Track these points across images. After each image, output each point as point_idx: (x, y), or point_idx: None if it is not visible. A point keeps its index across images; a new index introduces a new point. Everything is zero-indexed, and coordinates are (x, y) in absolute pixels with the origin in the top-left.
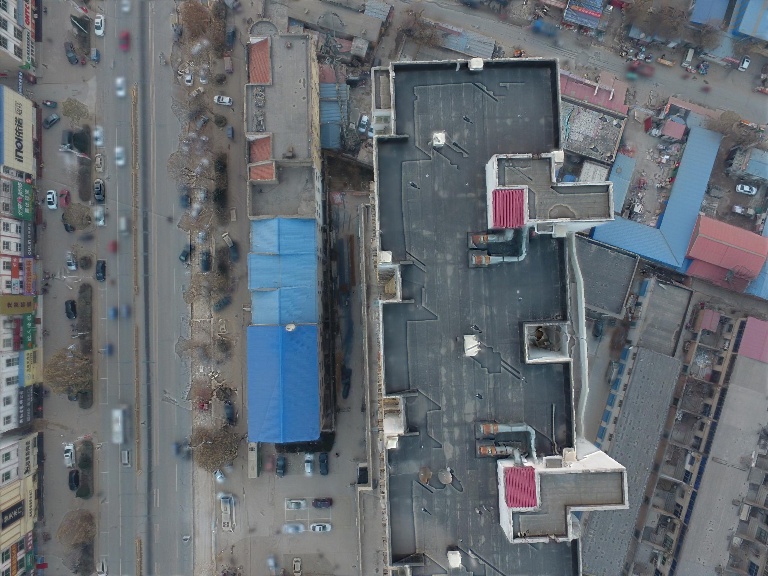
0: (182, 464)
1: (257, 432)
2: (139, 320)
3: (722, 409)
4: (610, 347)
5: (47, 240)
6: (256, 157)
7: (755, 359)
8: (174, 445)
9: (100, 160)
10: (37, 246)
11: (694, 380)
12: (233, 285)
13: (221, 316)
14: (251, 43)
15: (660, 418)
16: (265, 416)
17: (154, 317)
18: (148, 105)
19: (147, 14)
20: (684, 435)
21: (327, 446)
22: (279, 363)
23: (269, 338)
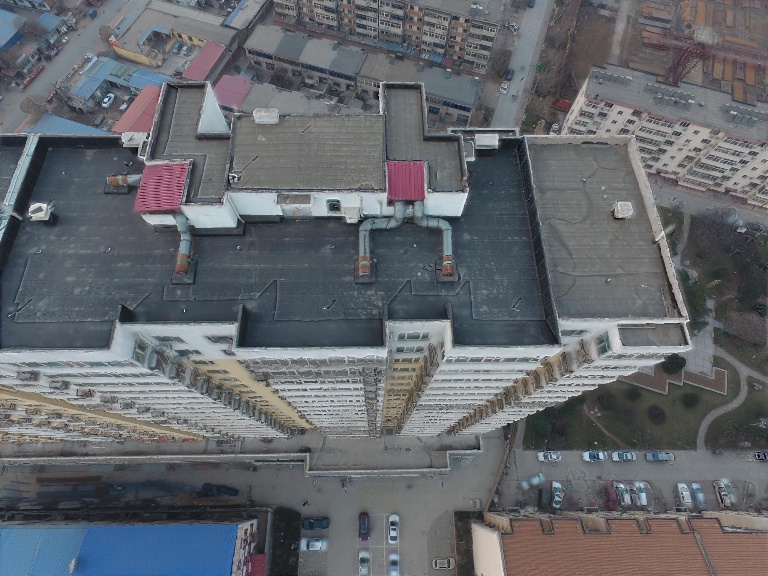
0: None
1: None
2: None
3: None
4: None
5: None
6: None
7: (244, 98)
8: None
9: None
10: None
11: None
12: None
13: None
14: None
15: None
16: None
17: None
18: None
19: None
20: None
21: (292, 518)
22: None
23: None
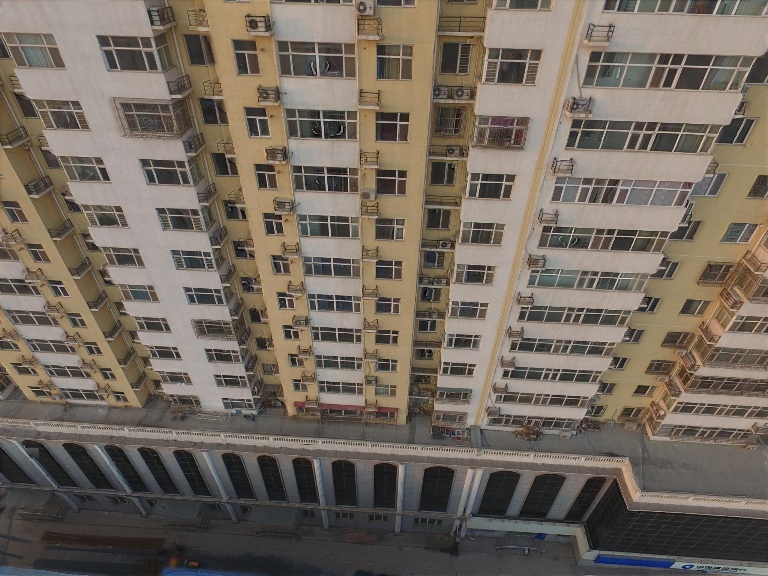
0: None
1: None
2: None
3: None
4: None
5: None
6: None
7: None
8: None
9: None
10: None
11: None
12: None
13: None
14: None
15: None
16: None
17: None
18: None
19: None
20: None
21: None
22: None
23: None
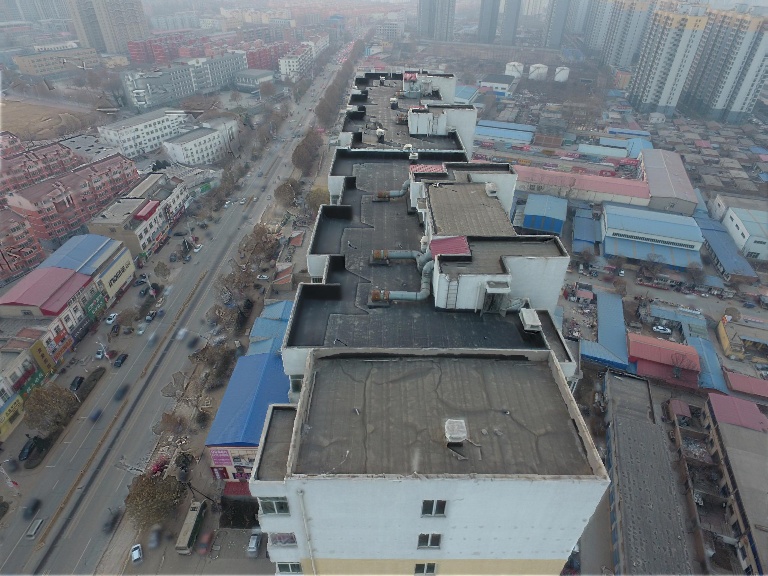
0: (98, 539)
1: (217, 435)
2: (132, 396)
3: (733, 472)
4: (592, 434)
5: (90, 341)
6: (280, 277)
7: (737, 425)
8: (101, 515)
9: (162, 300)
10: (79, 343)
11: (693, 459)
12: (230, 373)
13: (210, 396)
14: (292, 237)
15: (667, 480)
16: (231, 420)
17: (147, 394)
18: (210, 279)
19: (230, 245)
20: (720, 529)
21: None
22: (259, 377)
23: (256, 361)
